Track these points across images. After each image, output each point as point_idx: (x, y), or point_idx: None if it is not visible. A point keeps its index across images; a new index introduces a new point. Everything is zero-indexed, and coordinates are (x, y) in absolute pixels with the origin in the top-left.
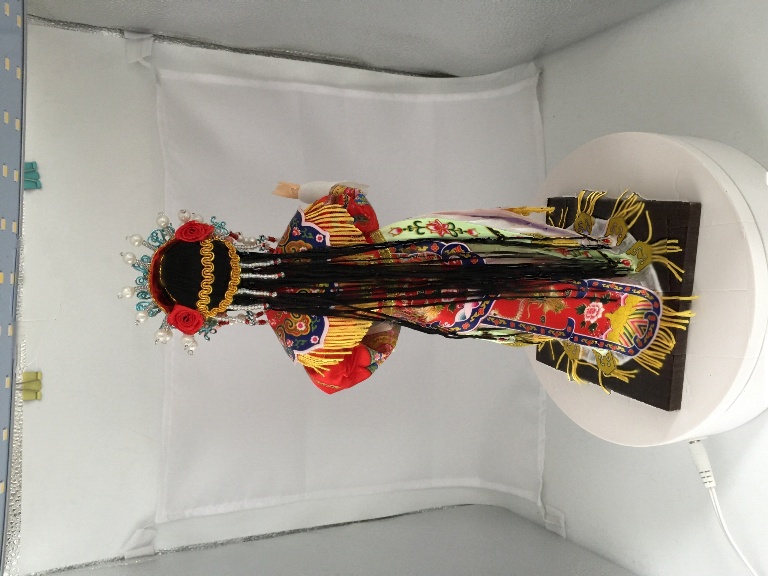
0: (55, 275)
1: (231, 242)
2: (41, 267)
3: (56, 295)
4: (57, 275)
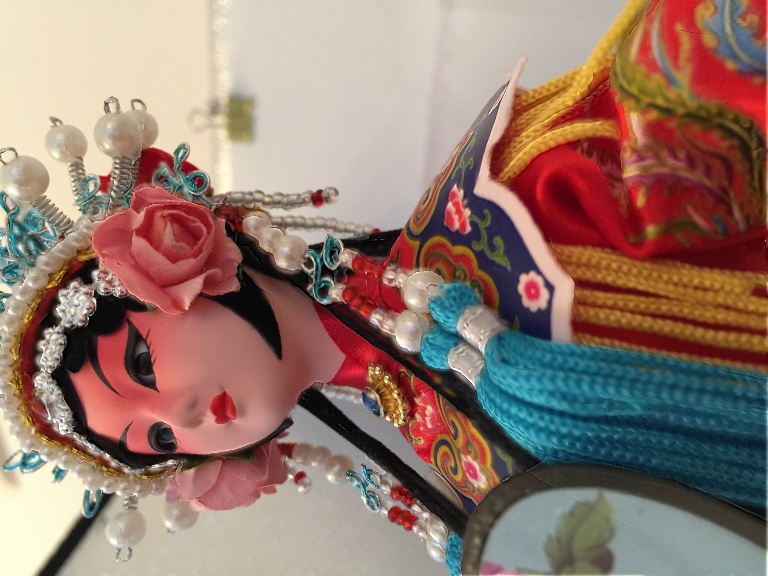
0: None
1: None
2: None
3: None
4: None
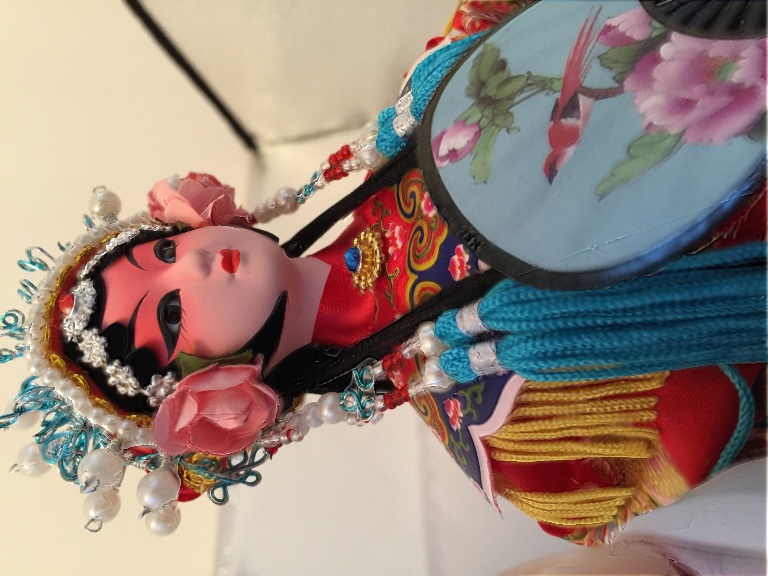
0: None
1: None
2: None
3: None
4: None
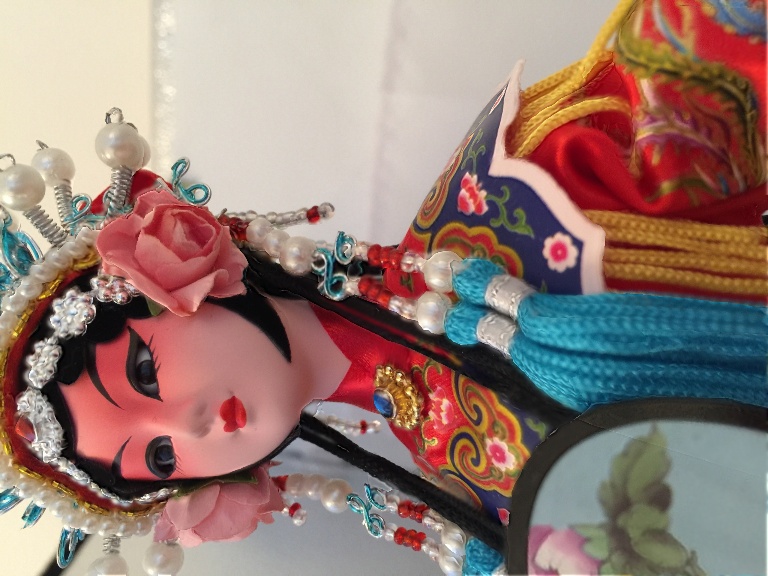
0: None
1: (270, 467)
2: None
3: None
4: None
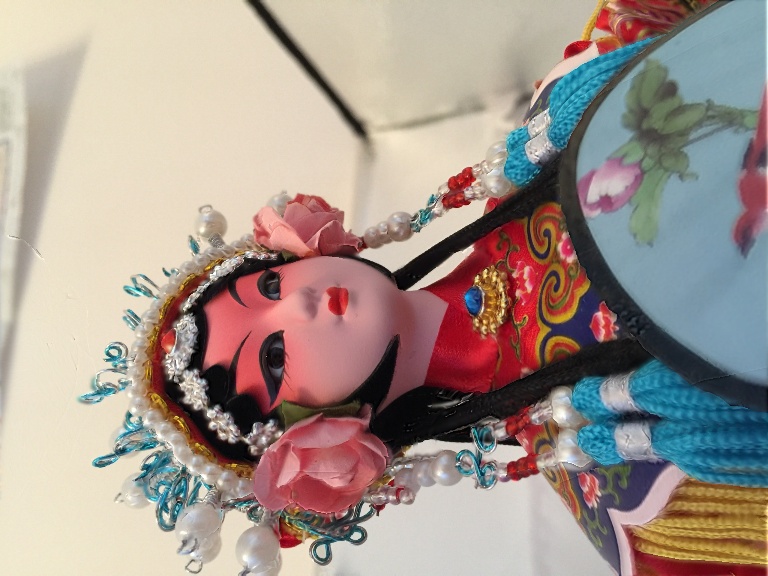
0: (53, 423)
1: None
2: (74, 450)
3: (81, 391)
4: (28, 415)
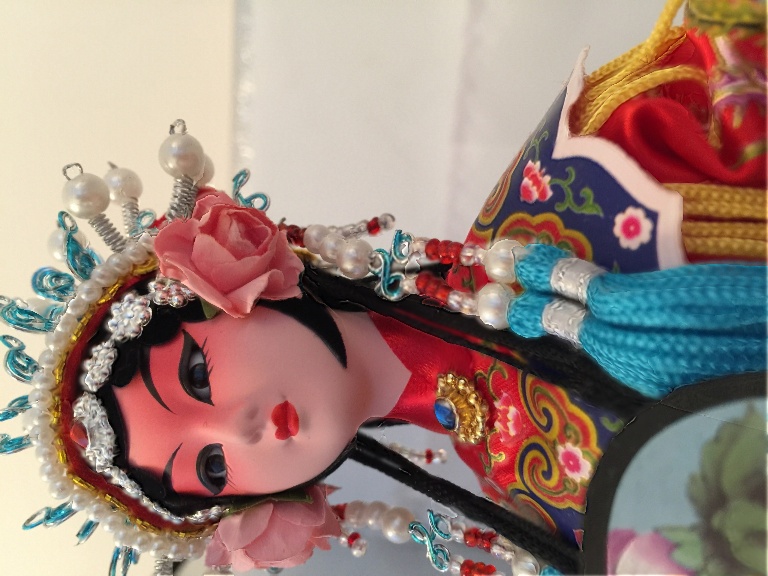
0: None
1: (329, 493)
2: None
3: None
4: None
